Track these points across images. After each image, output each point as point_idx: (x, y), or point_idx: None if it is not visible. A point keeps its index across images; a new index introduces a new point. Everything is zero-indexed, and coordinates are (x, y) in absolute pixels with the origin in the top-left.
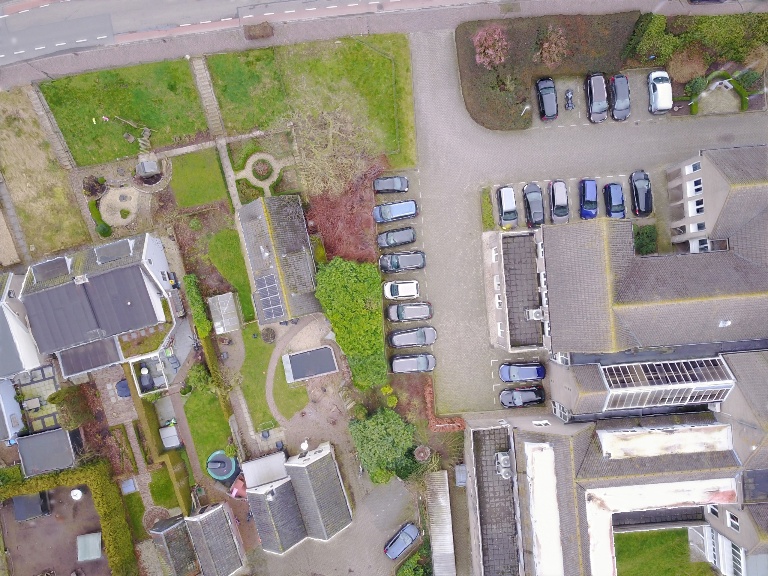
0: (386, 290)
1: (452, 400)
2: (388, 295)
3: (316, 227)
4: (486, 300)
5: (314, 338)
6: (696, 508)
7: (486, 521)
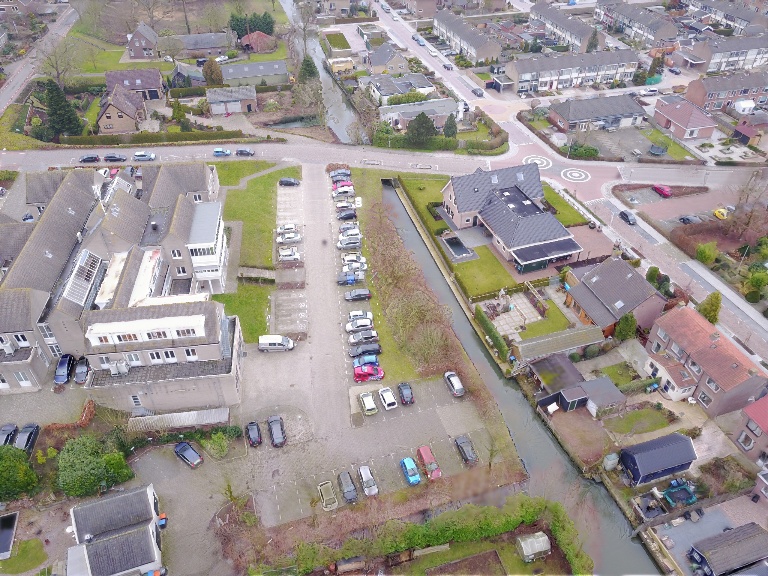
0: None
1: (71, 414)
2: None
3: None
4: (1, 395)
5: None
6: (186, 282)
7: None
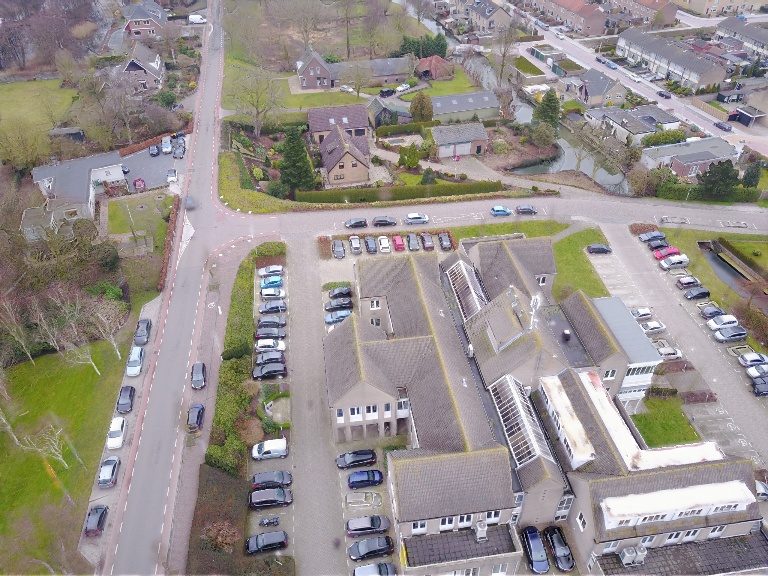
0: None
1: None
2: None
3: None
4: None
5: None
6: None
7: (696, 573)
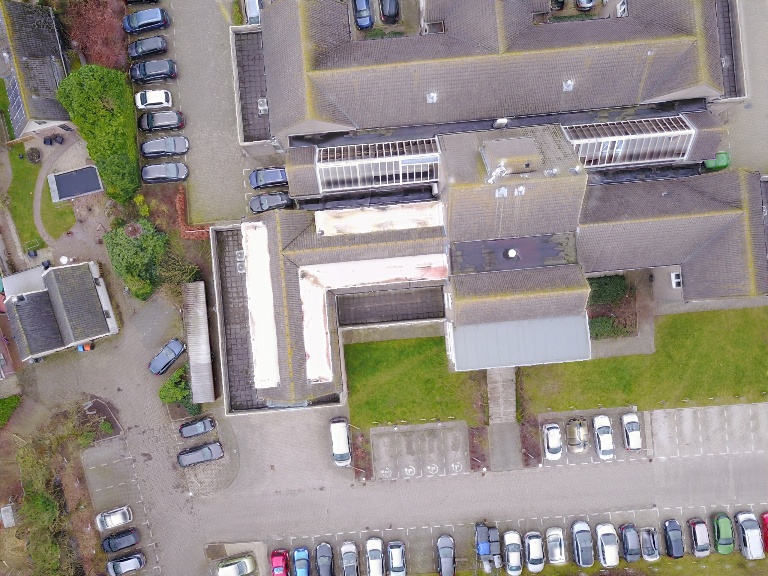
0: (137, 99)
1: (205, 210)
2: (138, 104)
3: (78, 46)
4: None
5: (79, 158)
6: (438, 306)
7: (230, 321)
